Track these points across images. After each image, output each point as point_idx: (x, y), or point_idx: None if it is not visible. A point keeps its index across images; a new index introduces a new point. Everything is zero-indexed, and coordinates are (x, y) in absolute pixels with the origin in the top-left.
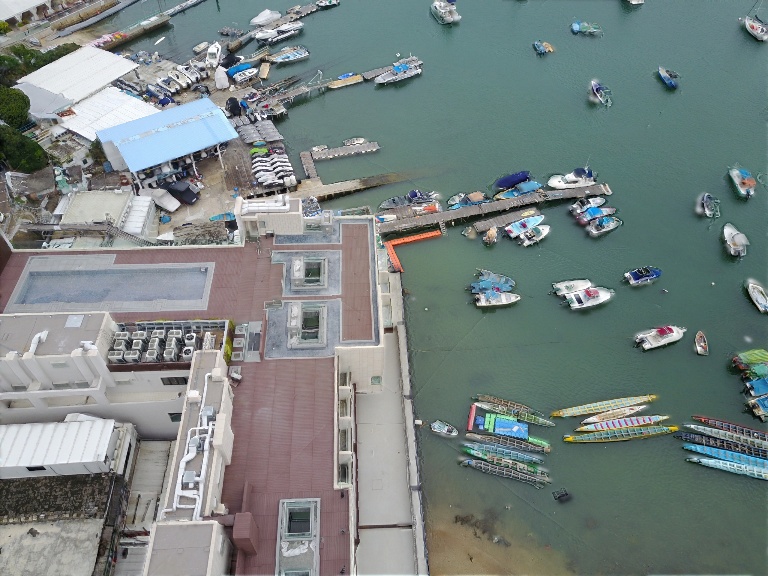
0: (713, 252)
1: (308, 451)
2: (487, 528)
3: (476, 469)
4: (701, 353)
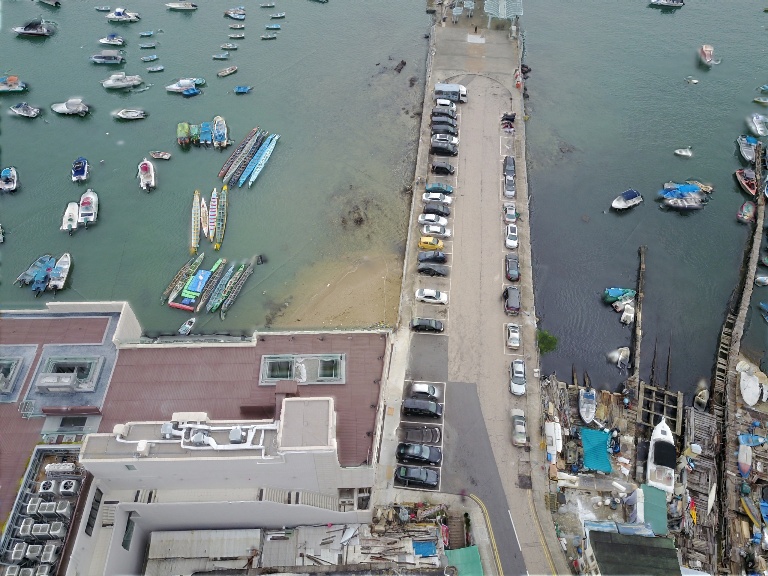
0: (73, 128)
1: (216, 367)
2: (277, 308)
3: (230, 308)
4: (168, 158)
